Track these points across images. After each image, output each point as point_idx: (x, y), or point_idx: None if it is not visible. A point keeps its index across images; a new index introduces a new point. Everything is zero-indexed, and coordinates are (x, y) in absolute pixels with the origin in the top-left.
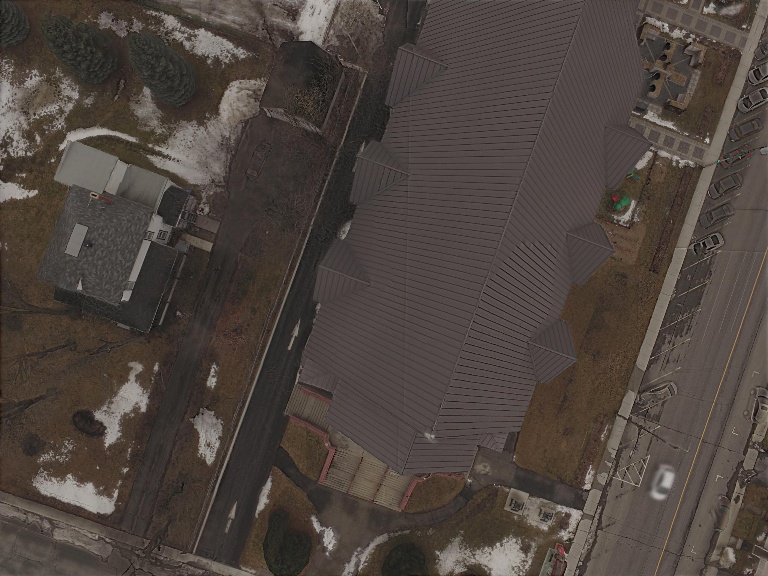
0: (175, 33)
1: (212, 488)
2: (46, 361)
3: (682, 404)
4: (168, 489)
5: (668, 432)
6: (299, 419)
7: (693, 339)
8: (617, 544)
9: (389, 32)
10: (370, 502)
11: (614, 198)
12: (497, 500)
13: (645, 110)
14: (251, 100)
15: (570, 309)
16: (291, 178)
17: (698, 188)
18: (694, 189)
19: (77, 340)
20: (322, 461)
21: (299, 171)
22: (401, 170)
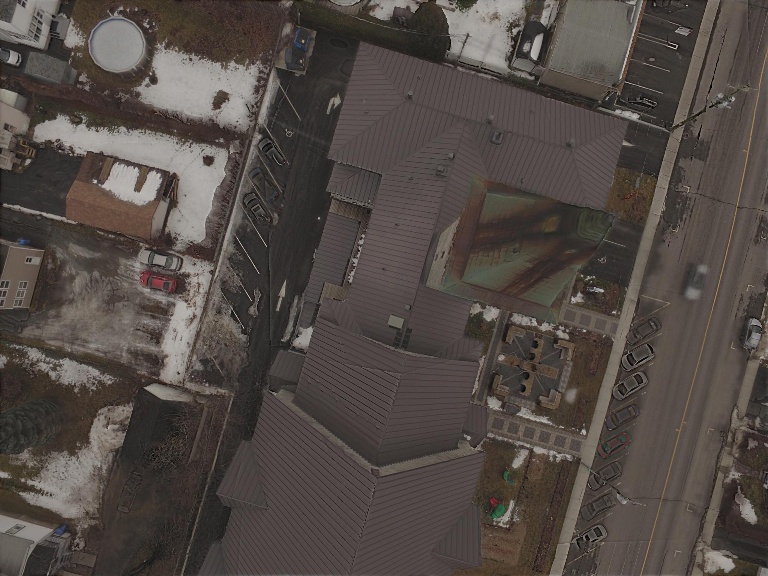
0: (40, 364)
1: None
2: None
3: None
4: None
5: None
6: None
7: None
8: None
9: (253, 351)
10: None
11: (492, 501)
12: None
13: (516, 412)
14: (118, 433)
15: None
16: (165, 504)
17: (577, 481)
18: (573, 482)
19: None
20: None
21: (173, 496)
22: None
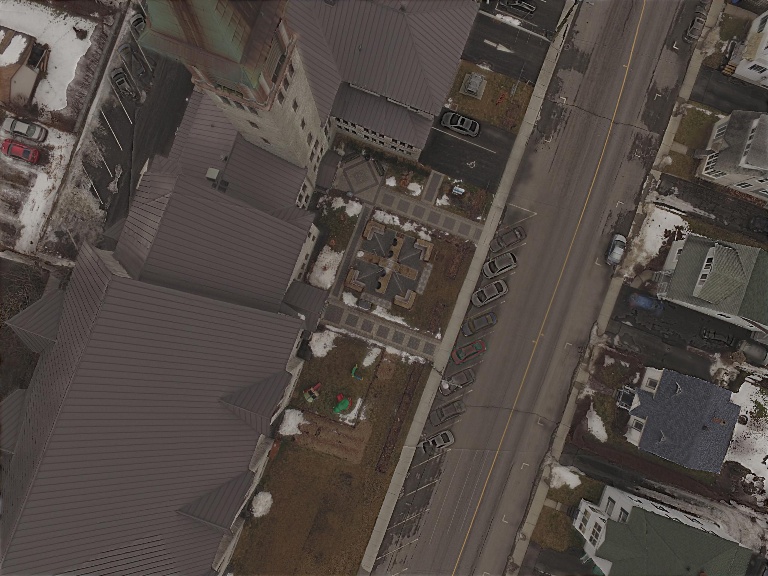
0: None
1: None
2: None
3: None
4: None
5: None
6: None
7: (421, 539)
8: None
9: None
10: None
11: (339, 397)
12: None
13: (369, 308)
14: None
15: (292, 510)
16: (10, 375)
17: (428, 385)
18: (424, 386)
19: None
20: None
21: (18, 368)
22: (7, 447)
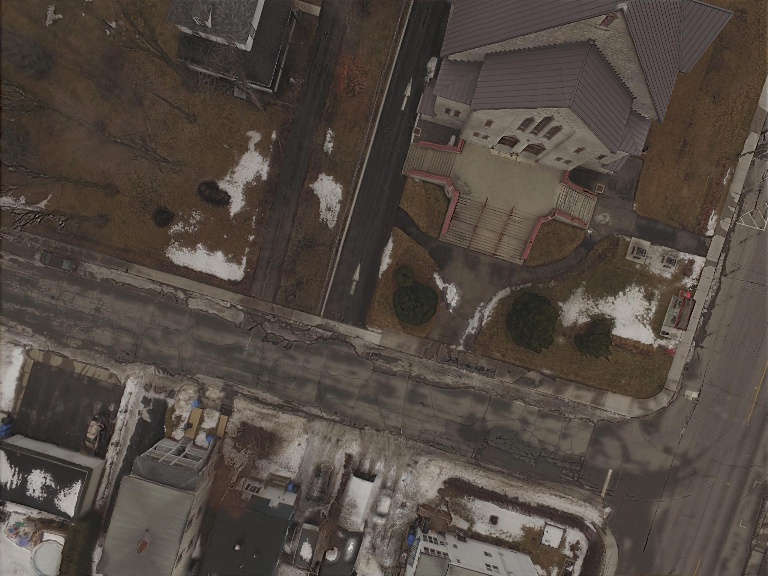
0: None
1: (336, 250)
2: (168, 135)
3: None
4: (293, 254)
5: None
6: (419, 171)
7: None
8: (742, 289)
9: None
10: (491, 257)
11: None
12: (618, 249)
13: None
14: None
15: None
16: None
17: None
18: None
19: (196, 113)
20: (442, 218)
21: None
22: None
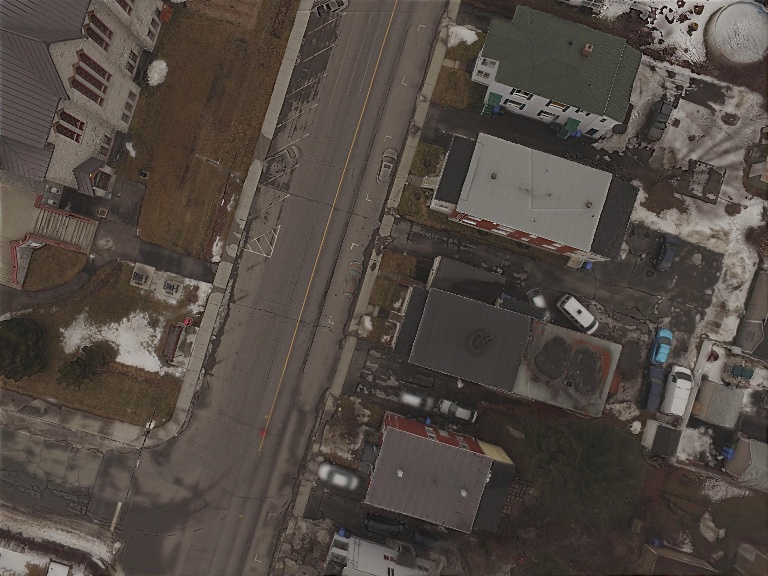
0: None
1: None
2: None
3: (311, 171)
4: None
5: (298, 200)
6: None
7: (320, 104)
8: (250, 316)
9: None
10: None
11: None
12: (121, 275)
13: None
14: None
15: (188, 77)
16: None
17: None
18: None
19: None
20: None
21: None
22: None
